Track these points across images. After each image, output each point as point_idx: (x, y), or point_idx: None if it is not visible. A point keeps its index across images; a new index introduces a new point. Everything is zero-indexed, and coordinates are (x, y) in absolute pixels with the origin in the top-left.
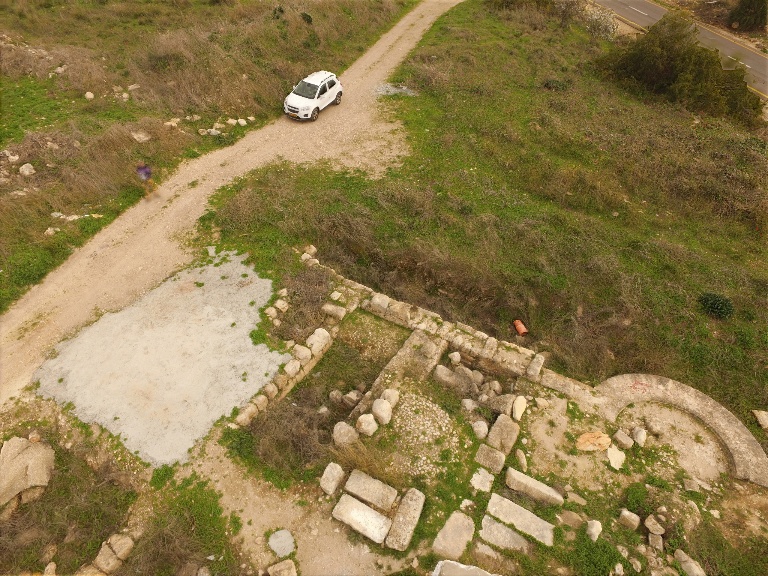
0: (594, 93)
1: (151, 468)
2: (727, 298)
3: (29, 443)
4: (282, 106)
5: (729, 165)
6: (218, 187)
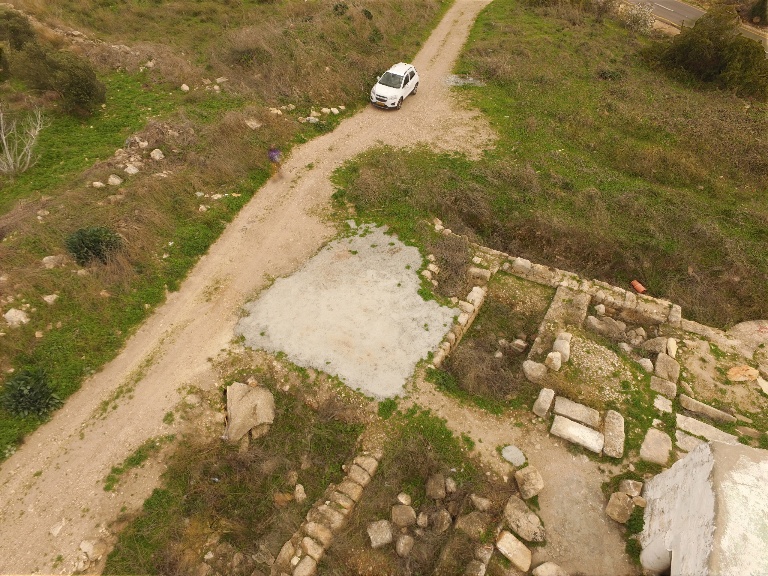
0: (646, 82)
1: (375, 401)
2: None
3: (249, 387)
4: (366, 96)
5: None
6: (334, 169)
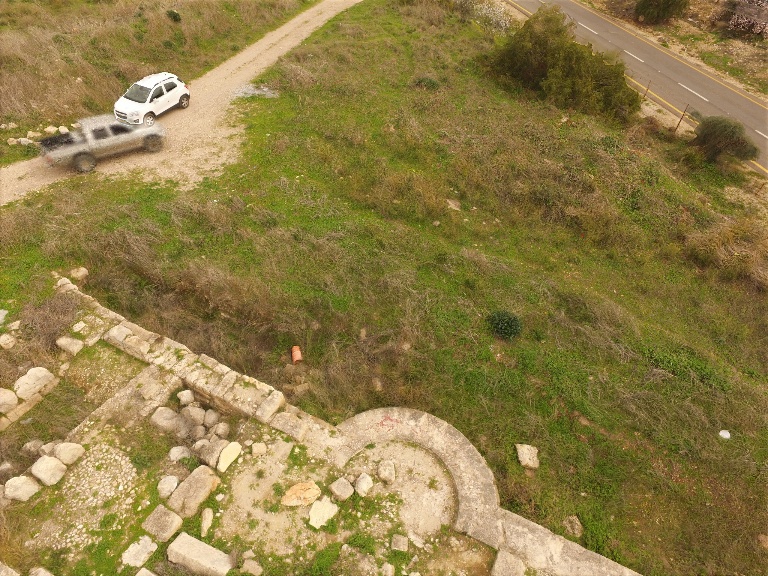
0: (468, 91)
1: None
2: (518, 316)
3: None
4: None
5: (577, 166)
6: (4, 203)
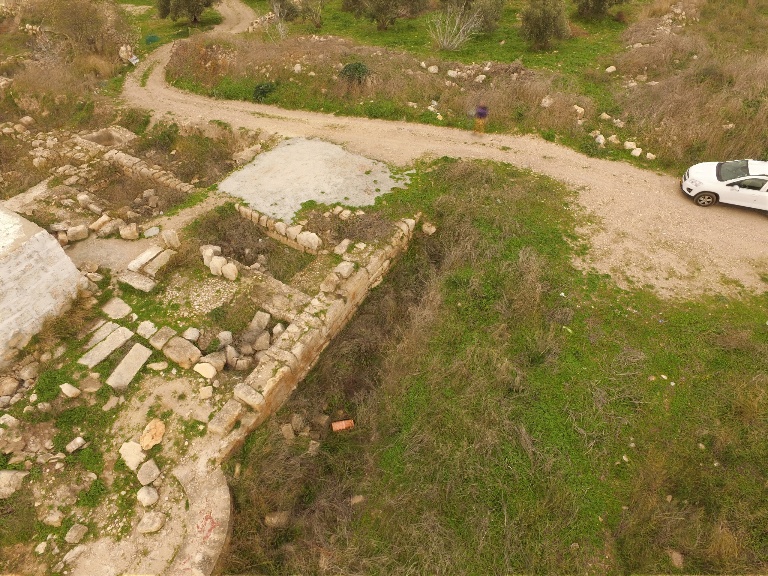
0: None
1: None
2: None
3: None
4: None
5: None
6: (507, 161)
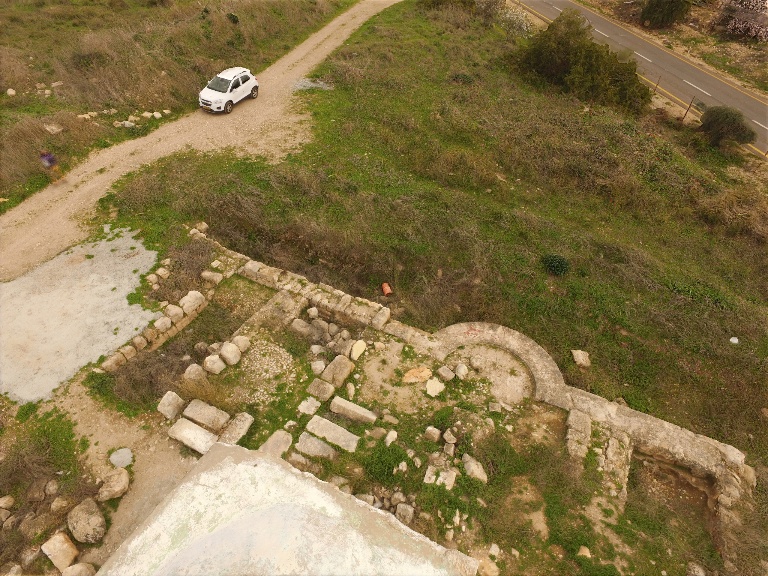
0: (499, 86)
1: (17, 405)
2: (565, 258)
3: None
4: None
5: (602, 147)
6: (124, 173)
